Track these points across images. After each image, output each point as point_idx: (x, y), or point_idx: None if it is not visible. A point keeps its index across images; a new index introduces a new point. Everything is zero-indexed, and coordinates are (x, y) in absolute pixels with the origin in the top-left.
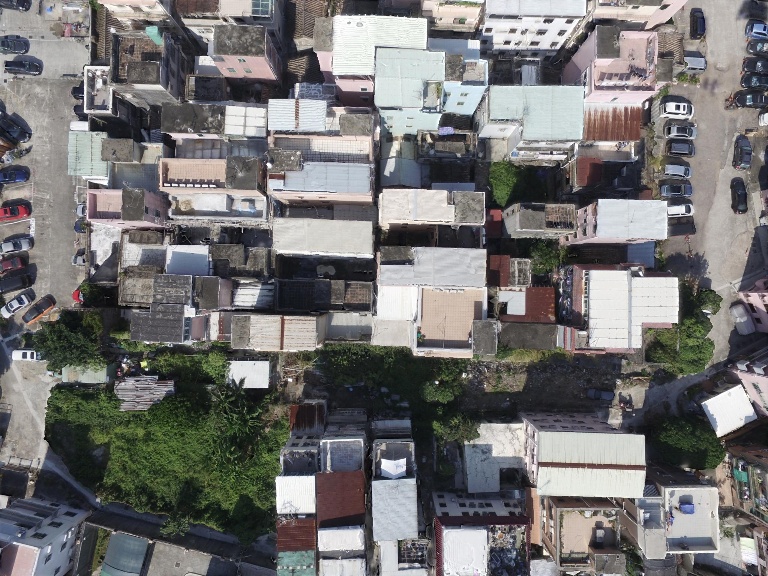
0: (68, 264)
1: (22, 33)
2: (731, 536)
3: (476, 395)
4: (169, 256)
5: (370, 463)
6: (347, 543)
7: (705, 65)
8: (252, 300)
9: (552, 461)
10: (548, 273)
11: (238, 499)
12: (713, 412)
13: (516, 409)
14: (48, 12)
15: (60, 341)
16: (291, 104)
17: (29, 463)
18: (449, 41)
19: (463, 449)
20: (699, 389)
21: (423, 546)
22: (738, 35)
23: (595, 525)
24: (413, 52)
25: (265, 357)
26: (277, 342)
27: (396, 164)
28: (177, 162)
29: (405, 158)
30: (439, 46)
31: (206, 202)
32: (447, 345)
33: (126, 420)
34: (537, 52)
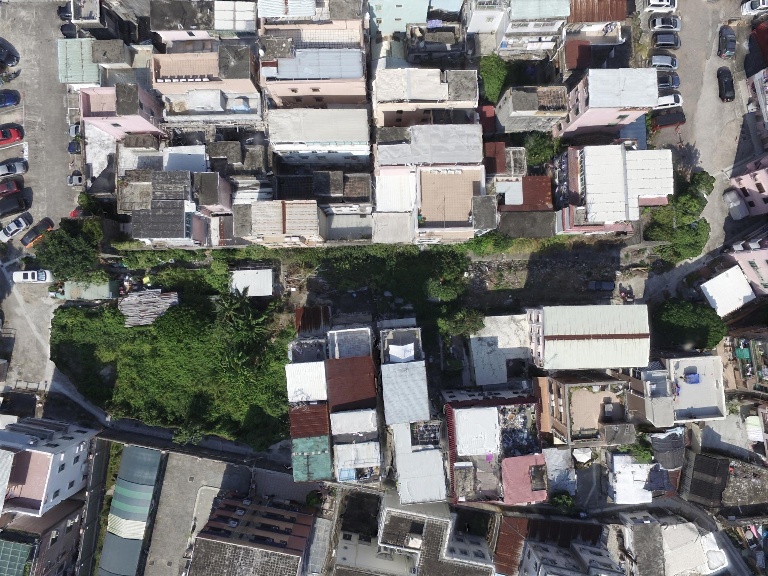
0: (64, 186)
1: None
2: (736, 413)
3: (479, 294)
4: (166, 158)
5: (378, 353)
6: (360, 427)
7: None
8: None
9: (558, 334)
10: (543, 164)
11: (248, 409)
12: (712, 294)
13: (519, 305)
14: None
15: (61, 246)
16: None
17: (36, 386)
18: None
19: (469, 344)
20: (697, 276)
21: (435, 428)
22: None
23: (603, 401)
24: None
25: (267, 266)
26: (279, 226)
27: (387, 63)
28: (169, 58)
29: (395, 57)
30: None
31: (200, 99)
32: (448, 226)
33: (131, 337)
34: None
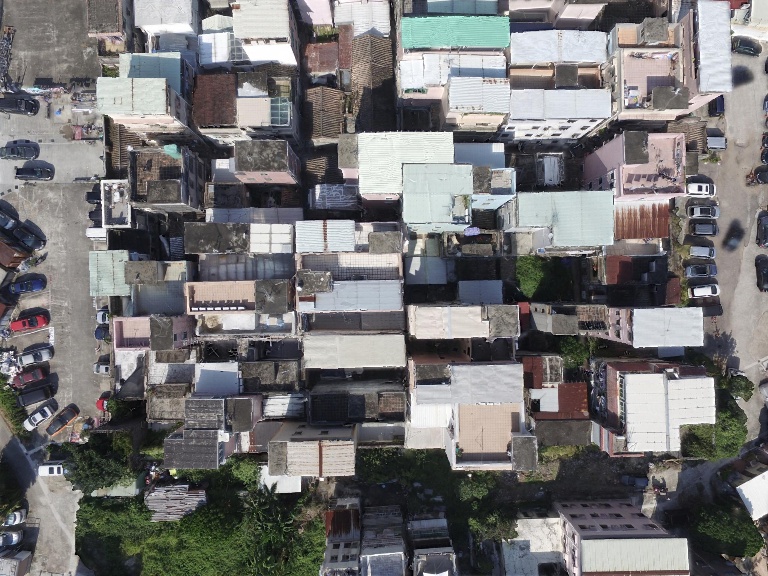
0: (90, 372)
1: (31, 137)
2: None
3: (509, 486)
4: (198, 374)
5: (411, 574)
6: None
7: (726, 144)
8: (282, 409)
9: (596, 570)
10: (579, 366)
11: None
12: (748, 496)
13: (550, 498)
14: (57, 115)
15: (91, 469)
16: (319, 226)
17: None
18: (473, 145)
19: (500, 545)
20: (732, 469)
21: None
22: (757, 110)
23: None
24: (440, 166)
25: None
26: (316, 469)
27: (421, 263)
28: (203, 285)
29: (430, 256)
30: (463, 151)
31: (234, 322)
32: (486, 458)
33: (157, 529)
34: (558, 140)
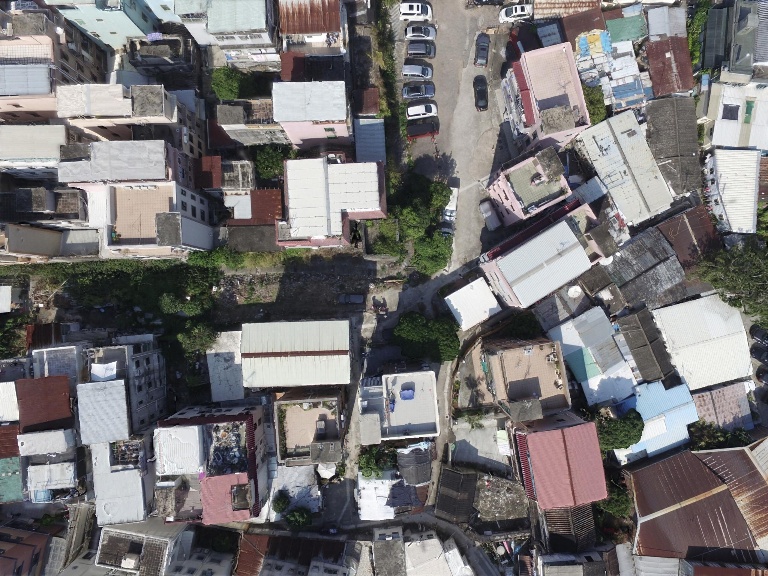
0: None
1: None
2: (478, 427)
3: (229, 308)
4: None
5: None
6: (54, 448)
7: None
8: None
9: (254, 352)
10: (278, 177)
11: None
12: (457, 306)
13: (269, 319)
14: None
15: None
16: None
17: None
18: None
19: None
20: (452, 288)
21: (136, 447)
22: None
23: (319, 418)
24: None
25: None
26: None
27: (117, 76)
28: None
29: (128, 71)
30: None
31: None
32: (143, 243)
33: None
34: None
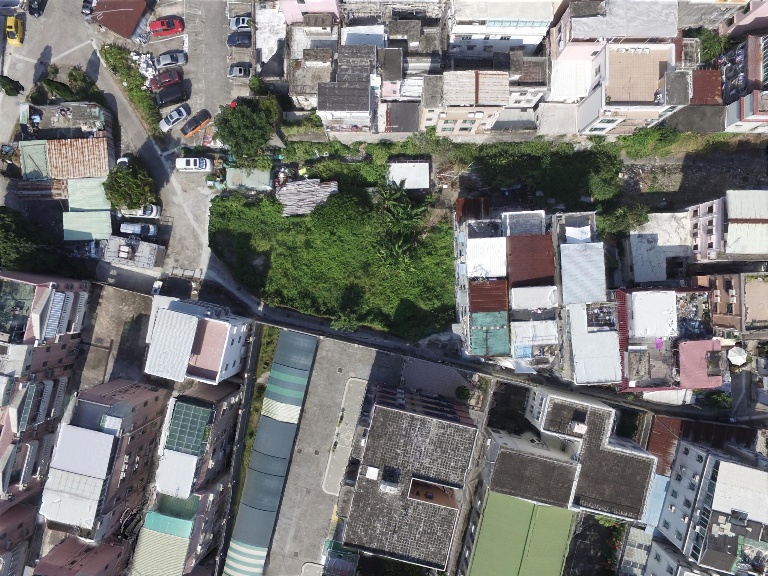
0: (222, 79)
1: None
2: None
3: (632, 196)
4: (344, 38)
5: None
6: None
7: None
8: (418, 91)
9: (742, 217)
10: (711, 60)
11: (399, 302)
12: None
13: (673, 208)
14: None
15: (244, 119)
16: None
17: (192, 273)
18: None
19: (626, 242)
20: None
21: (611, 310)
22: None
23: None
24: None
25: (423, 160)
26: (472, 96)
27: None
28: None
29: None
30: None
31: None
32: None
33: (286, 227)
34: None
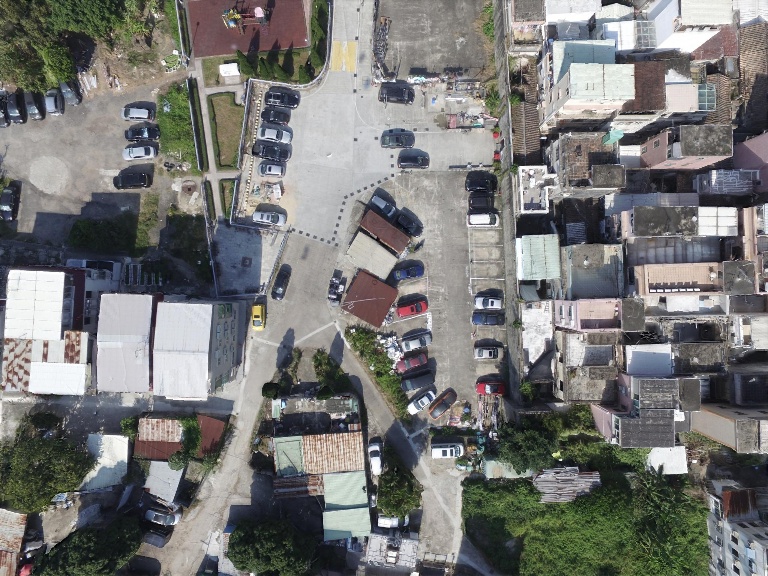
0: (466, 356)
1: (406, 126)
2: None
3: None
4: (629, 356)
5: None
6: None
7: None
8: None
9: None
10: None
11: None
12: None
13: None
14: (432, 104)
15: (539, 449)
16: None
17: (444, 558)
18: None
19: None
20: None
21: None
22: None
23: None
24: None
25: (677, 442)
26: None
27: None
28: (658, 267)
29: None
30: None
31: (679, 303)
32: None
33: (541, 511)
34: None
